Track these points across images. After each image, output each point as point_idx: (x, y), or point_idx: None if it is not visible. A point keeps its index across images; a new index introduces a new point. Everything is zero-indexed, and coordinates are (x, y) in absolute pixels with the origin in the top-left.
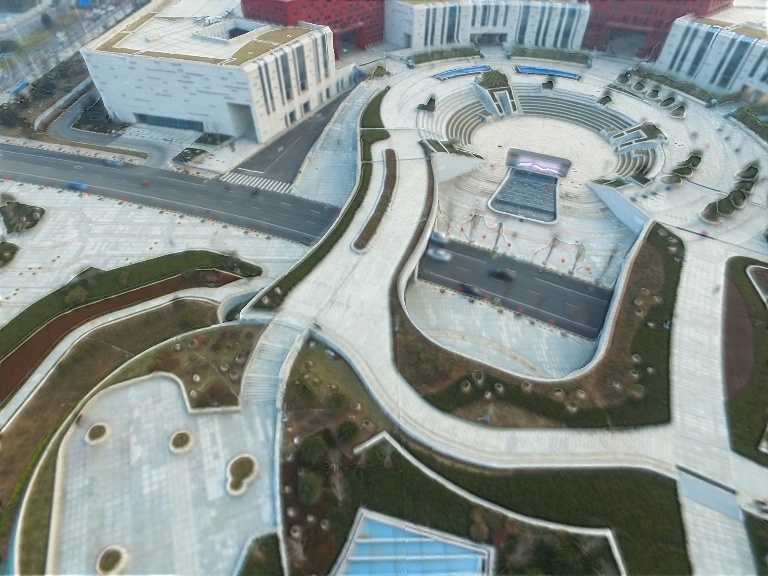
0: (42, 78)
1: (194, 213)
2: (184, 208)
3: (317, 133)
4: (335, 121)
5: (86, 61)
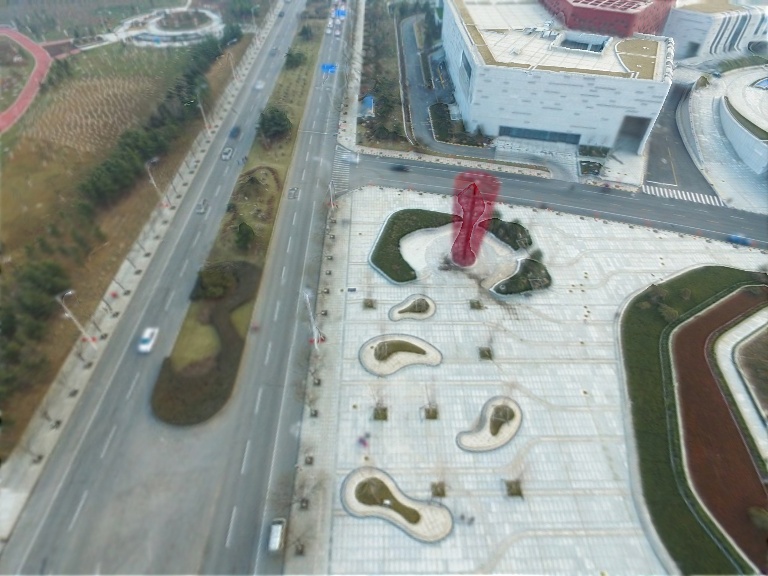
0: (363, 91)
1: (662, 227)
2: (647, 222)
3: (680, 144)
4: (696, 132)
5: (479, 76)
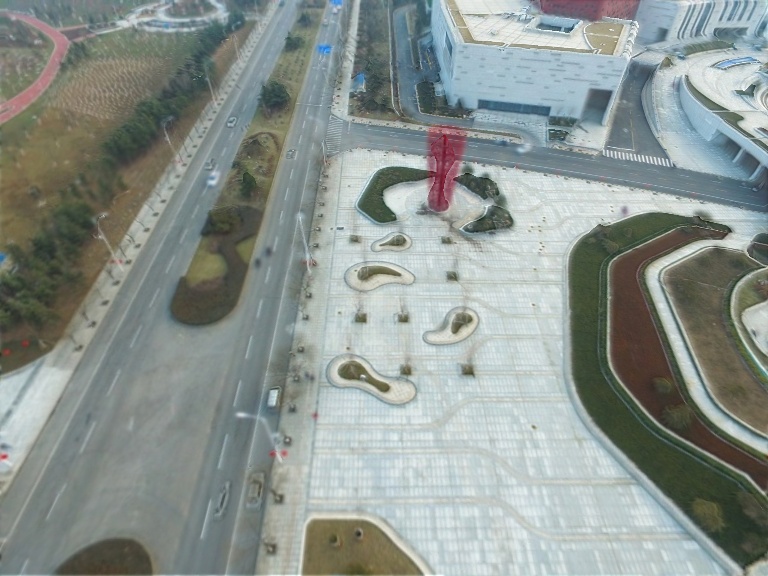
0: (355, 70)
1: (616, 183)
2: (603, 179)
3: (642, 117)
4: (656, 106)
5: (458, 53)
